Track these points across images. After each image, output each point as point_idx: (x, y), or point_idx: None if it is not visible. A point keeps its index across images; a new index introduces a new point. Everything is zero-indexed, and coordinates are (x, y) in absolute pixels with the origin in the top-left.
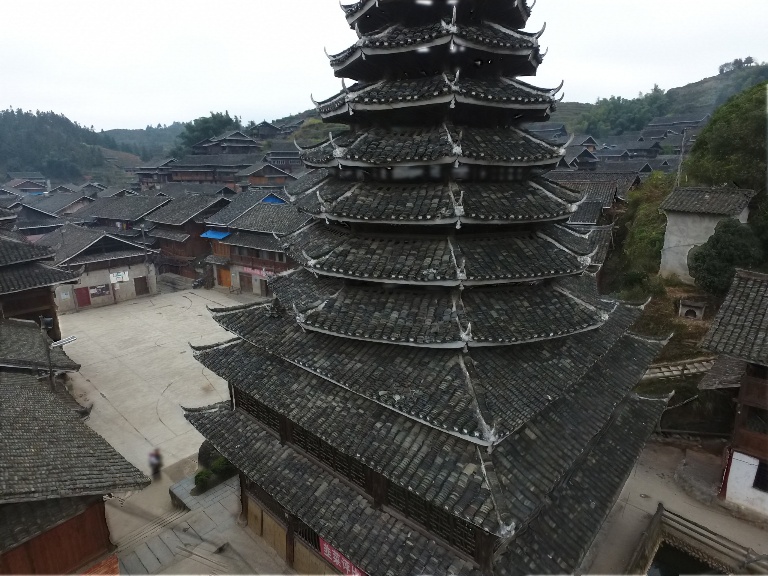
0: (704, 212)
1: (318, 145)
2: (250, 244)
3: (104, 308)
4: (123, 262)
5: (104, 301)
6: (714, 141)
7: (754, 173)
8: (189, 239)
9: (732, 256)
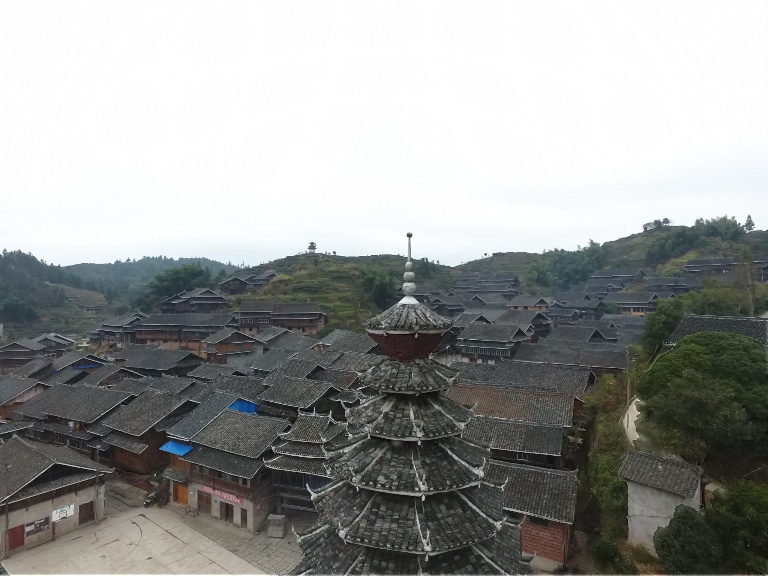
0: (660, 489)
1: (297, 574)
2: (213, 465)
3: (39, 549)
4: (70, 489)
5: (40, 538)
6: (657, 411)
7: (698, 452)
8: (147, 448)
9: (695, 553)
